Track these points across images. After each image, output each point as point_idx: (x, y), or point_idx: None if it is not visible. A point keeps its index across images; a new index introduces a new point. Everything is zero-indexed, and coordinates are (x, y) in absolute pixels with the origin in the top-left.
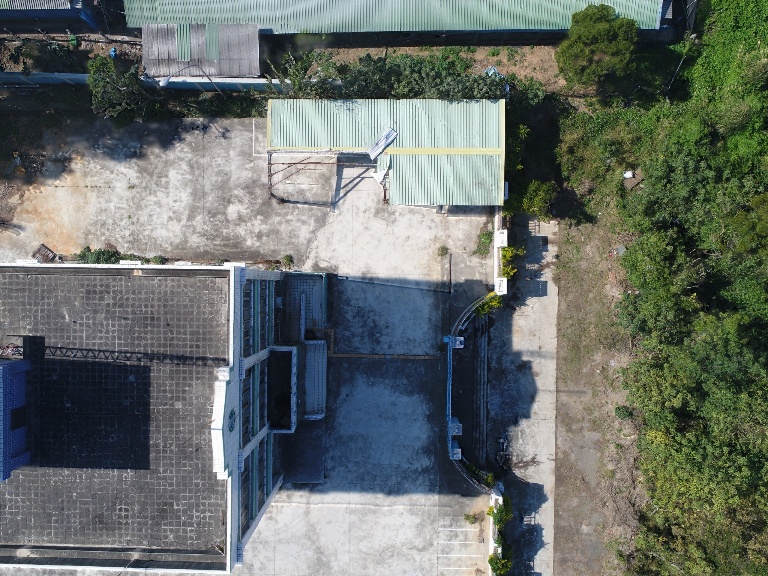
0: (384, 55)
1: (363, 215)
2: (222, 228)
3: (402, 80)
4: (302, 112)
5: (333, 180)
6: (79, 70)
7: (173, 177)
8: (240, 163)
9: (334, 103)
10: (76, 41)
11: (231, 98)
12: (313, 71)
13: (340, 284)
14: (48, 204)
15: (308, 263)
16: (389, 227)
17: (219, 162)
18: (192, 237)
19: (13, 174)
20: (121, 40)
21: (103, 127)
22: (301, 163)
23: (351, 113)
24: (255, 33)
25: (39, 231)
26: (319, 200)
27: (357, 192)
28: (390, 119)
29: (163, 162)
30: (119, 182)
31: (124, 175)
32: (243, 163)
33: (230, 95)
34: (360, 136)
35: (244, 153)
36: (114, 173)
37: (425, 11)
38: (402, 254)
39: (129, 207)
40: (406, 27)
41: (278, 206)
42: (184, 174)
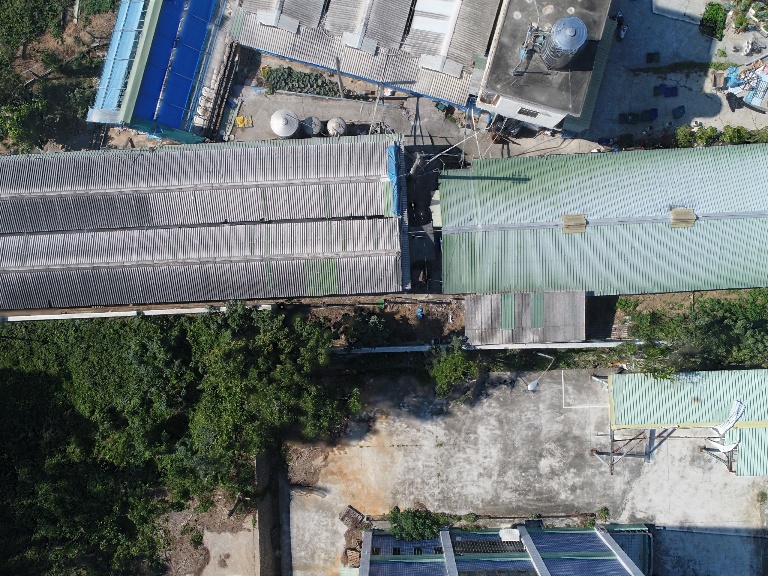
0: (692, 300)
1: (678, 464)
2: (534, 483)
3: (742, 348)
4: (644, 387)
5: (647, 430)
6: (397, 341)
7: (482, 433)
8: (550, 416)
9: (676, 376)
10: (383, 304)
11: (540, 352)
12: (621, 320)
13: (658, 534)
14: (353, 465)
15: (624, 515)
16: (706, 475)
17: (529, 416)
18: (504, 493)
19: (317, 437)
20: (428, 301)
21: (407, 385)
22: (645, 438)
23: (695, 386)
24: (582, 300)
25: (345, 492)
26: (633, 451)
27: (672, 441)
28: (736, 391)
29: (471, 418)
30: (426, 440)
31: (431, 433)
32: (553, 416)
33: (538, 349)
34: (707, 410)
35: (554, 406)
36: (421, 431)
37: (753, 270)
38: (720, 501)
39: (438, 465)
40: (732, 285)
41: (591, 458)
42: (493, 429)
